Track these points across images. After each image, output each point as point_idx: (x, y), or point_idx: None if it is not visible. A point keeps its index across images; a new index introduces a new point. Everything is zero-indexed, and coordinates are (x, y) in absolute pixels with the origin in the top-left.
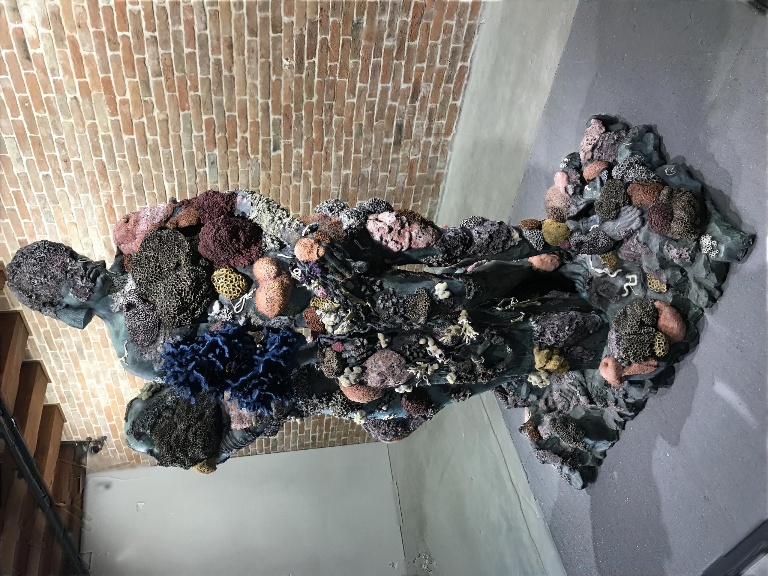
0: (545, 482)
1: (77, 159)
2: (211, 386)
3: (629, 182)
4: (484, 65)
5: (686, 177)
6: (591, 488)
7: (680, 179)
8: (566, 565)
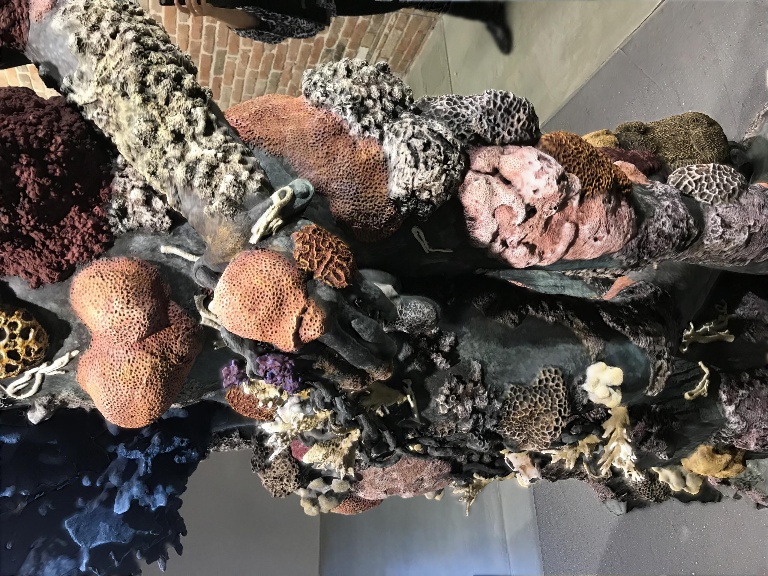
0: None
1: None
2: None
3: None
4: None
5: None
6: None
7: None
8: (544, 543)
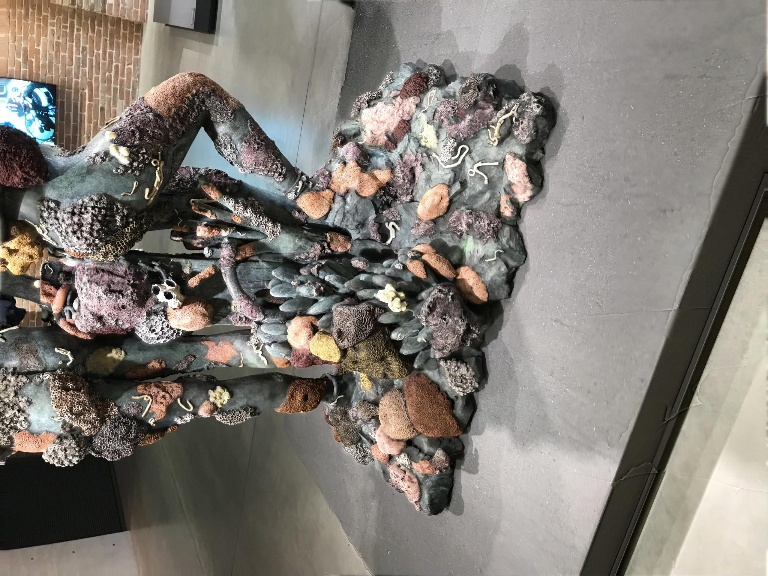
0: None
1: None
2: None
3: None
4: None
5: None
6: None
7: None
8: None
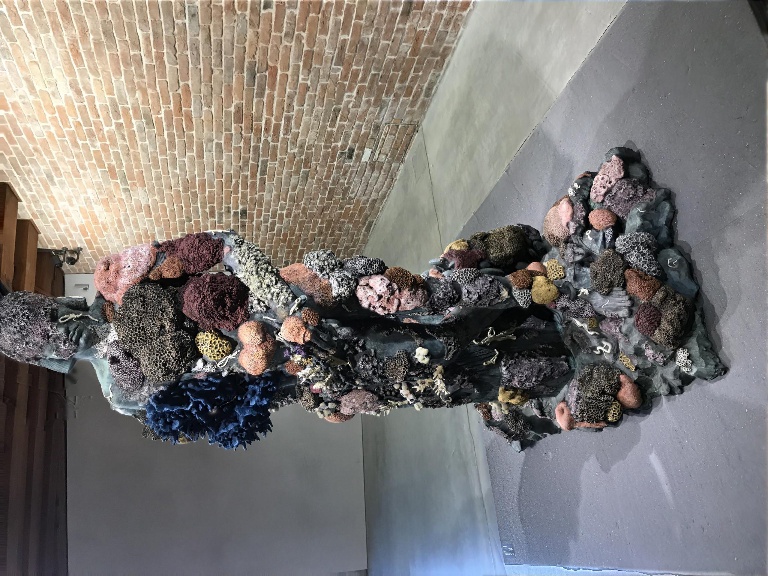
0: None
1: None
2: (193, 432)
3: (629, 262)
4: None
5: (686, 276)
6: (528, 449)
7: (679, 276)
8: (493, 486)
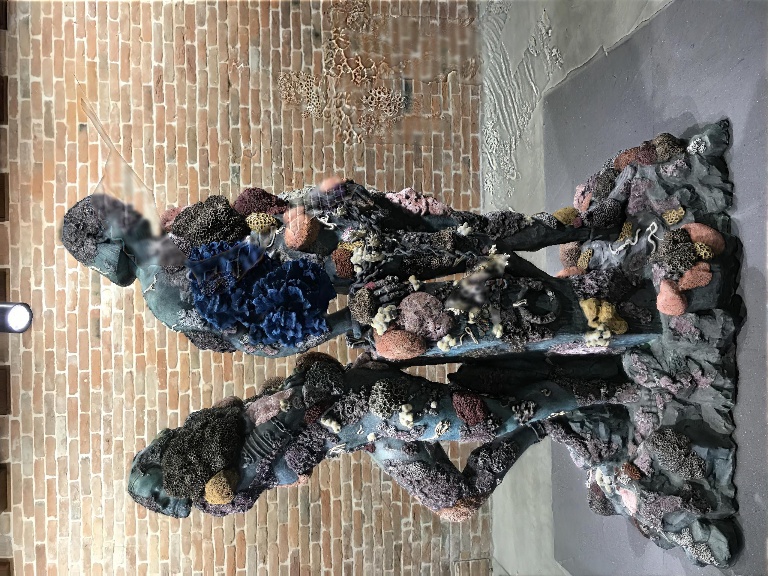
0: None
1: (119, 439)
2: (237, 288)
3: None
4: None
5: None
6: (745, 561)
7: None
8: None
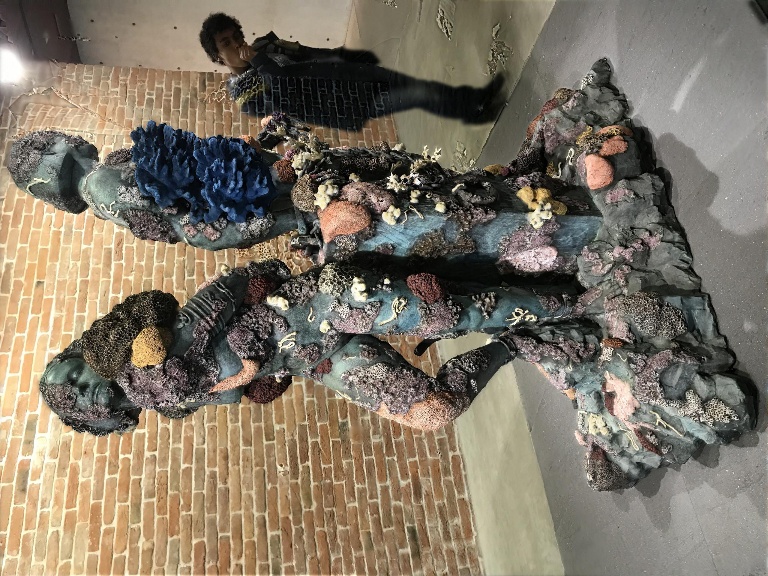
0: (761, 567)
1: None
2: (178, 149)
3: None
4: (469, 434)
5: None
6: (764, 405)
7: None
8: None
